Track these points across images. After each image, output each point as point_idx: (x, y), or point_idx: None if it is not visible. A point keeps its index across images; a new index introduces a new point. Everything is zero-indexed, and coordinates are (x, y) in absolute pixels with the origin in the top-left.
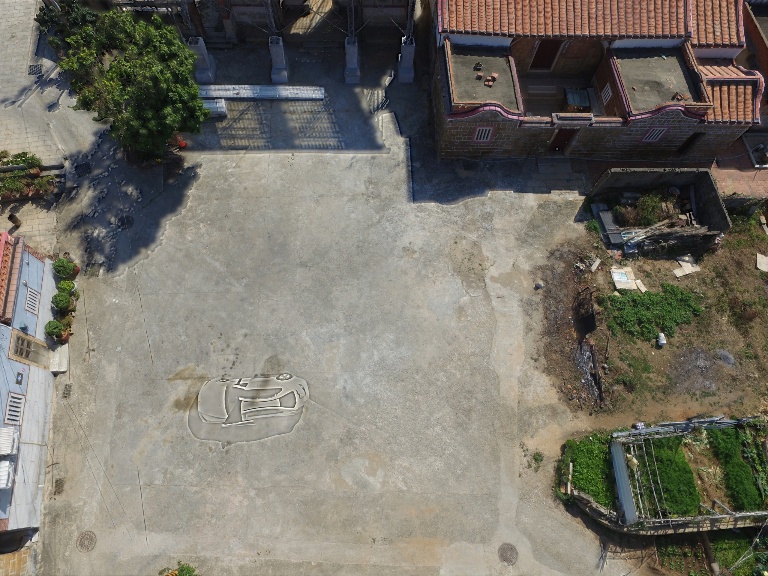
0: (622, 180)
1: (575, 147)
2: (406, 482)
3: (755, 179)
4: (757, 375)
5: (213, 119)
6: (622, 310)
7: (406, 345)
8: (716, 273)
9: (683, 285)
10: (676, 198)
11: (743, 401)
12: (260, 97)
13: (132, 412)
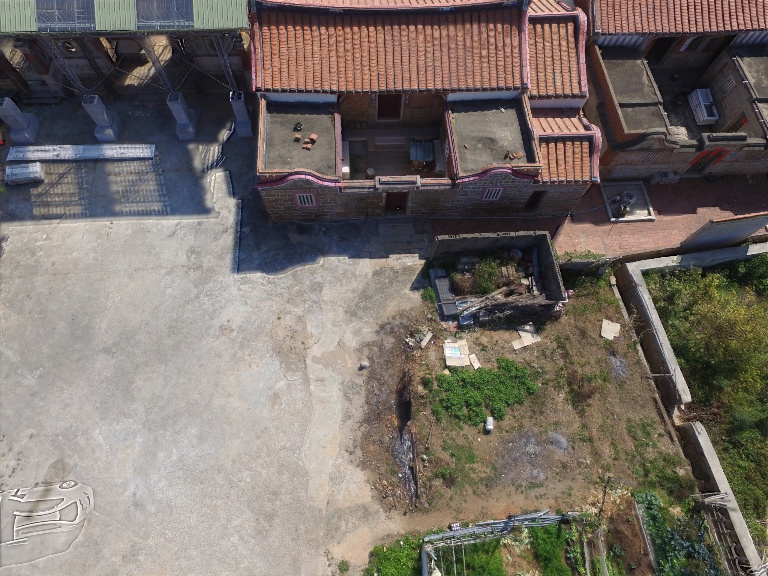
0: (456, 245)
1: (413, 207)
2: None
3: (610, 234)
4: (589, 460)
5: (28, 185)
6: (449, 391)
7: (210, 441)
8: (557, 343)
9: (520, 358)
10: (517, 262)
11: (571, 491)
12: (83, 158)
13: None
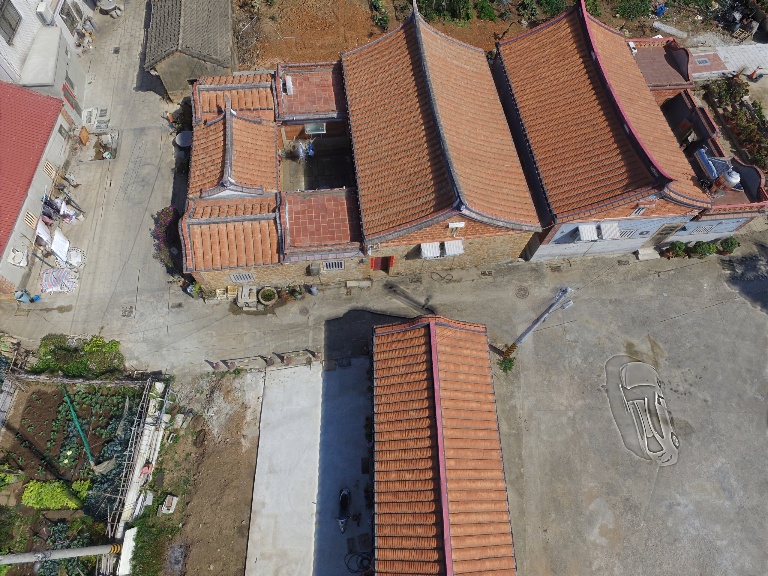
0: None
1: None
2: (600, 570)
3: None
4: None
5: None
6: None
7: None
8: None
9: None
10: None
11: None
12: None
13: (616, 311)
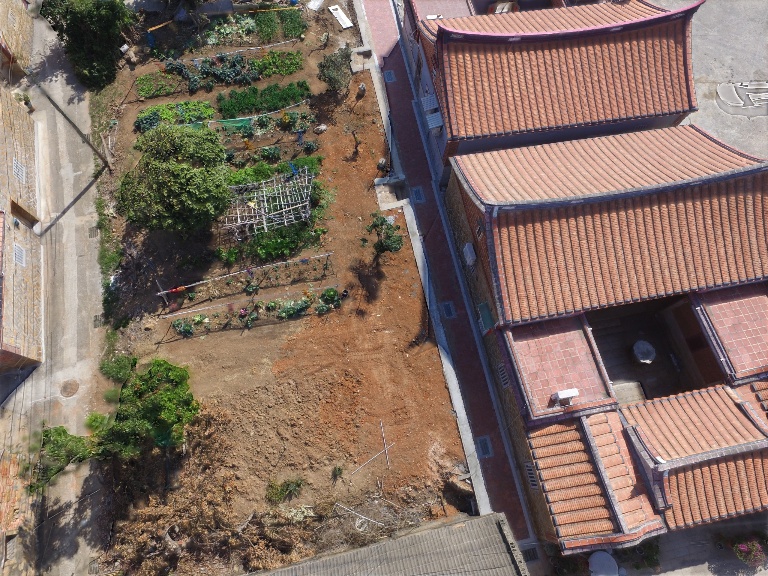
0: None
1: None
2: None
3: None
4: None
5: None
6: None
7: None
8: None
9: None
10: None
11: None
12: None
13: None
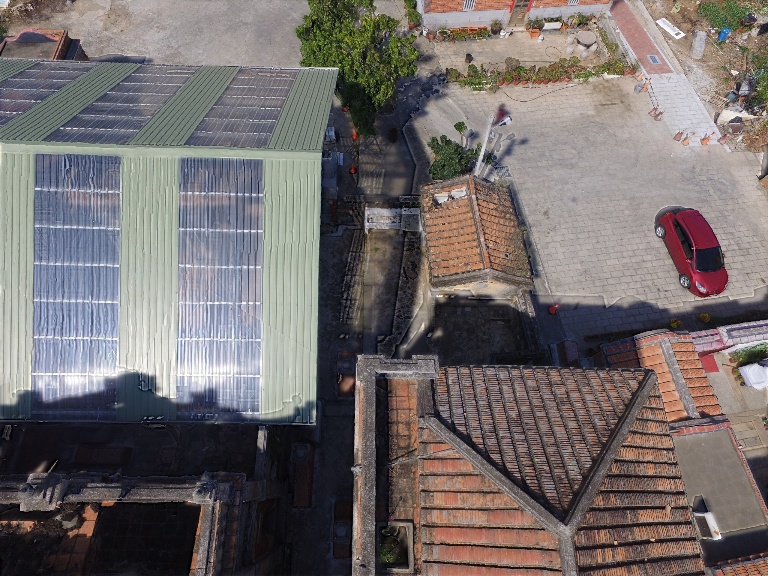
0: None
1: None
2: None
3: None
4: None
5: None
6: None
7: None
8: None
9: None
10: None
11: None
12: None
13: None
